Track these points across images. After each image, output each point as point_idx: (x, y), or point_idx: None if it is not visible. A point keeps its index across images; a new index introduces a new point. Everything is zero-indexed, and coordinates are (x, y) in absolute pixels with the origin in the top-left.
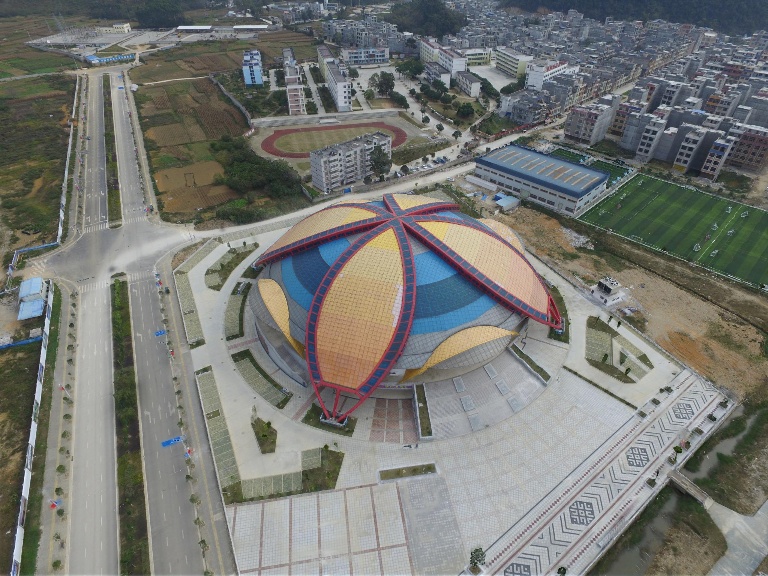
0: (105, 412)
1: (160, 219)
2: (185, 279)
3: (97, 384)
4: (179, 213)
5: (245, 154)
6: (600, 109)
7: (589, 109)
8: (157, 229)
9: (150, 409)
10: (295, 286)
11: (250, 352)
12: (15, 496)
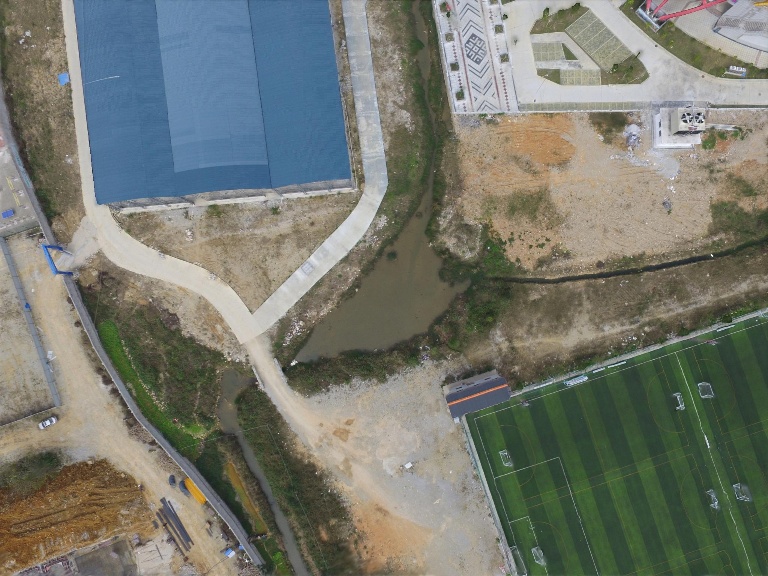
0: None
1: None
2: None
3: None
4: None
5: None
6: None
7: None
8: None
9: None
10: None
11: None
12: None
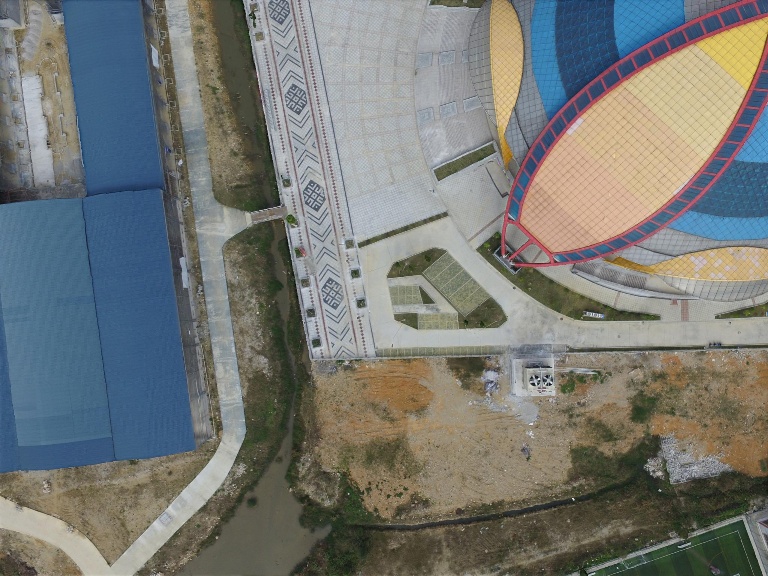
0: None
1: None
2: None
3: None
4: None
5: None
6: None
7: None
8: None
9: None
10: None
11: None
12: None
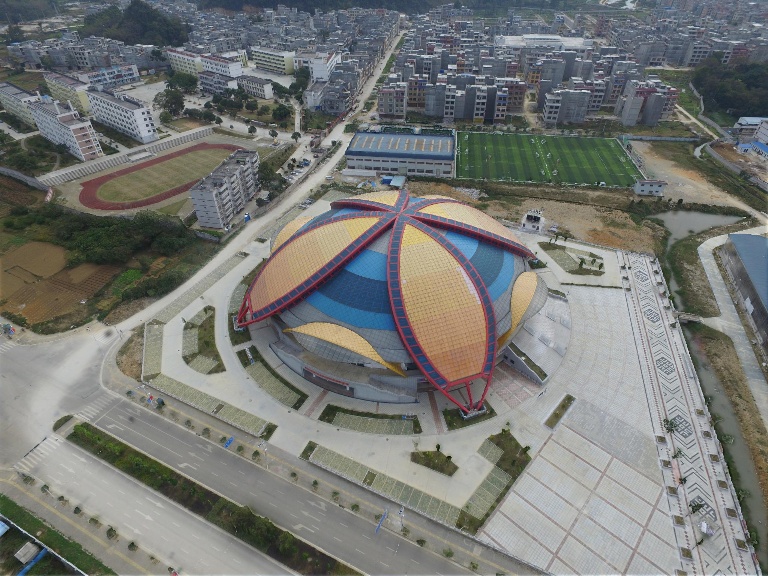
0: (249, 561)
1: (38, 335)
2: (167, 380)
3: (198, 544)
4: (62, 316)
5: (81, 219)
6: (402, 86)
7: (393, 88)
8: (49, 347)
9: (297, 521)
10: (354, 315)
11: (334, 406)
12: None
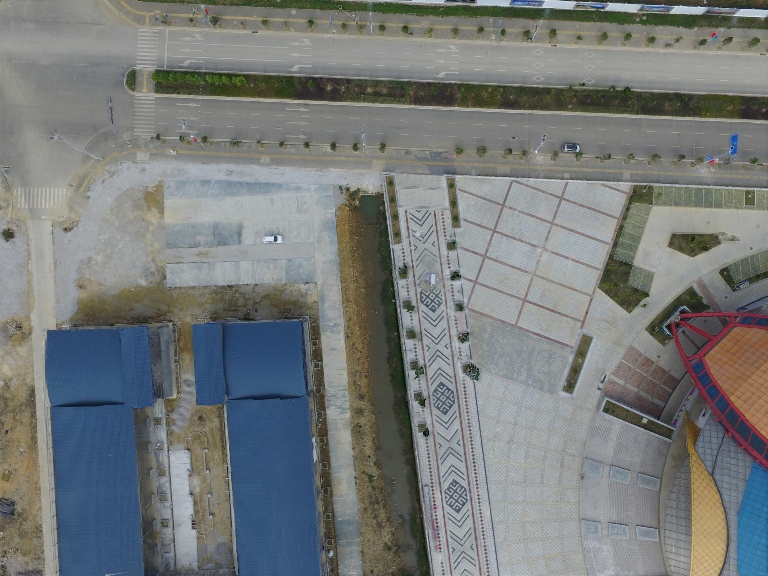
0: None
1: None
2: None
3: None
4: None
5: None
6: None
7: None
8: None
9: None
10: None
11: None
12: (743, 3)
